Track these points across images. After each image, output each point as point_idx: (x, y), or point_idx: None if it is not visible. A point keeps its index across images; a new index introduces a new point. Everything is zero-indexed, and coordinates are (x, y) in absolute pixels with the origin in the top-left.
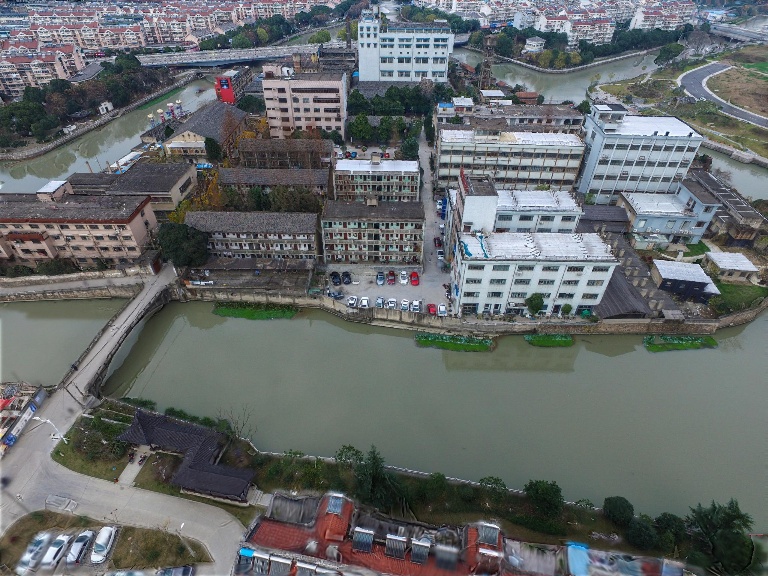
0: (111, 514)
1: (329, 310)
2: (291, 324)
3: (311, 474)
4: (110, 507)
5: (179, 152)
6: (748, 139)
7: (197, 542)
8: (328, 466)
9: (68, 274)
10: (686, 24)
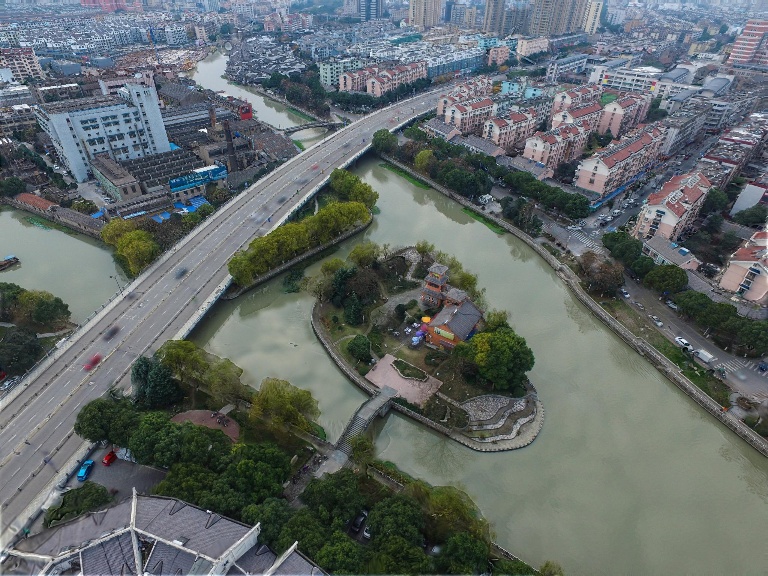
0: None
1: None
2: None
3: None
4: None
5: None
6: None
7: None
8: None
9: None
10: None
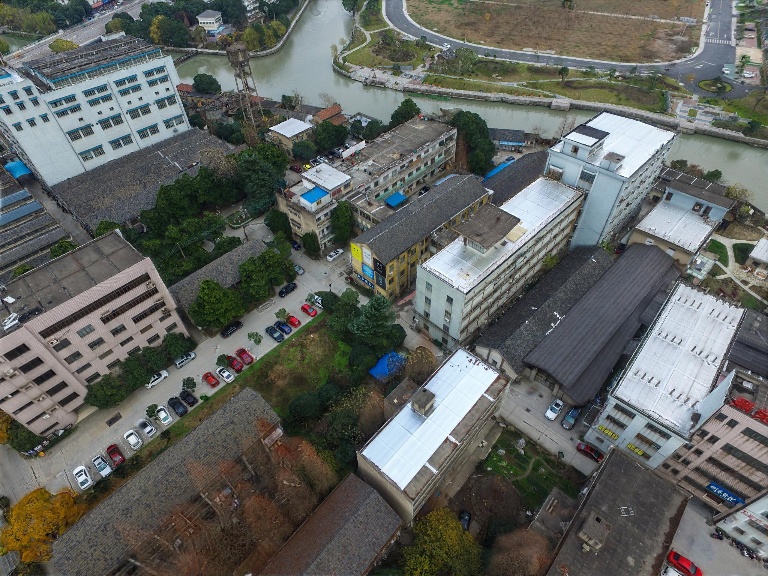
0: None
1: None
2: None
3: None
4: None
5: None
6: (542, 83)
7: None
8: None
9: None
10: None
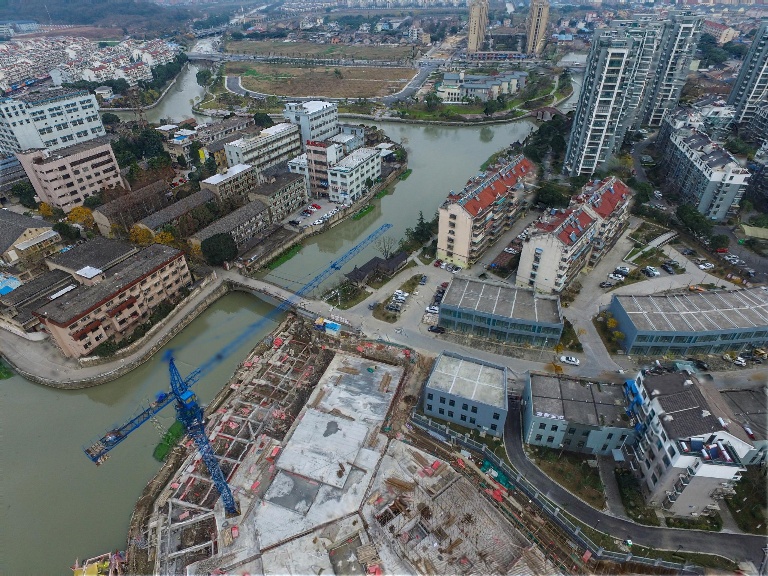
0: (388, 295)
1: (310, 235)
2: (307, 248)
3: (404, 249)
4: (384, 295)
5: (34, 250)
6: None
7: (414, 276)
8: (403, 246)
9: (172, 310)
10: (176, 56)
